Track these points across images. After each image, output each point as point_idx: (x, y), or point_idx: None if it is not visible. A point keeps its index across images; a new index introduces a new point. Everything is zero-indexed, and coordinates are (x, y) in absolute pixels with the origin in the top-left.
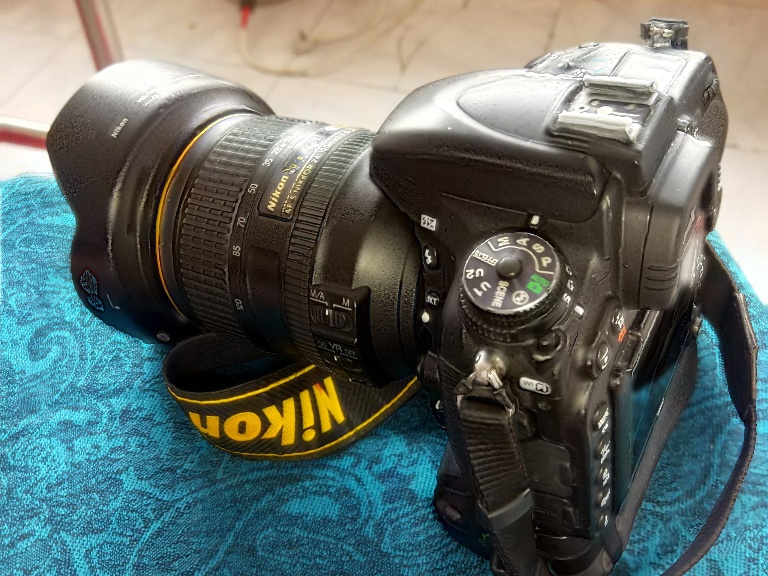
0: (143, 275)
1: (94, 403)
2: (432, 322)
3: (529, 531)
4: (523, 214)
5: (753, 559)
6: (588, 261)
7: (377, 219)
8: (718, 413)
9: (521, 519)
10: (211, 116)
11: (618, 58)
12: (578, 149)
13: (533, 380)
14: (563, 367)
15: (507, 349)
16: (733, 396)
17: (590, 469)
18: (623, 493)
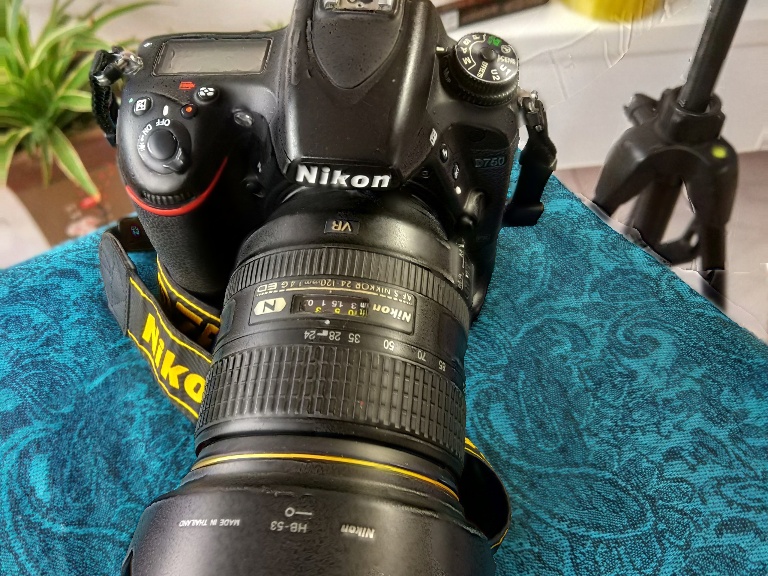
0: None
1: None
2: None
3: None
4: None
5: None
6: (447, 37)
7: (399, 218)
8: None
9: None
10: (274, 461)
11: (172, 77)
12: (404, 3)
13: None
14: None
15: None
16: None
17: None
18: None
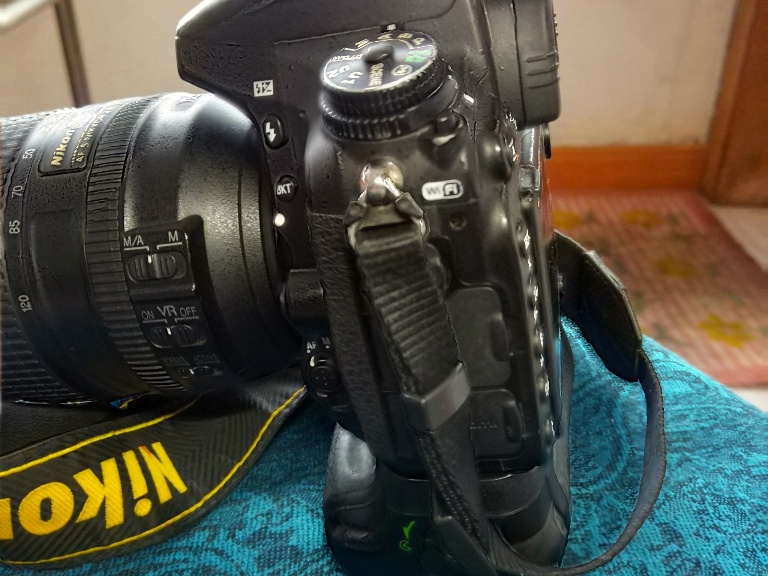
0: None
1: None
2: (289, 221)
3: (470, 449)
4: (375, 28)
5: (702, 511)
6: (461, 58)
7: (196, 139)
8: (605, 391)
9: (460, 414)
10: None
11: None
12: None
13: (438, 182)
14: (470, 154)
15: (398, 149)
16: (614, 367)
17: (526, 318)
18: (558, 404)
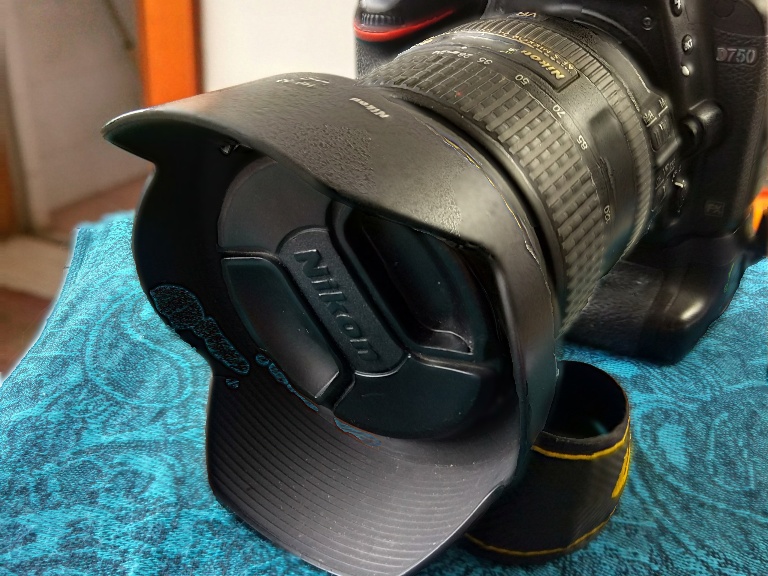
0: None
1: None
2: (691, 69)
3: None
4: None
5: None
6: None
7: None
8: None
9: None
10: None
11: None
12: None
13: None
14: None
15: None
16: None
17: None
18: None
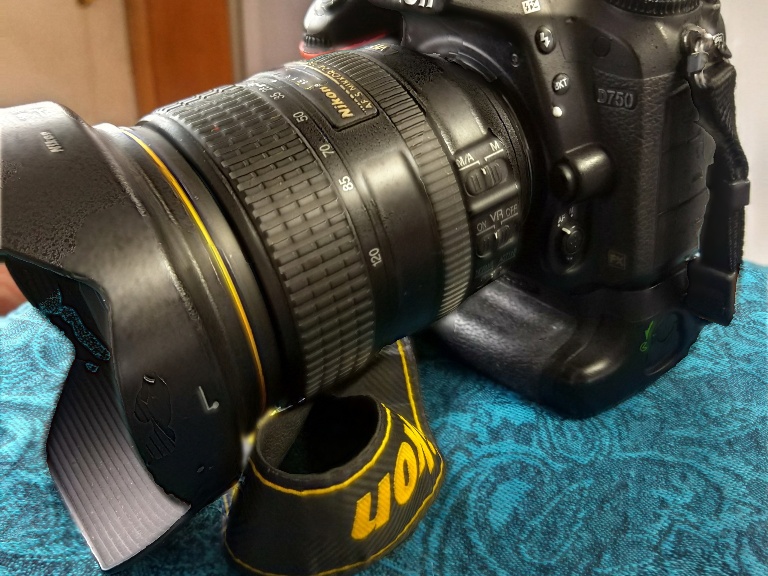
0: (222, 327)
1: None
2: (565, 110)
3: None
4: None
5: None
6: None
7: None
8: None
9: None
10: None
11: None
12: None
13: None
14: None
15: (695, 17)
16: None
17: None
18: None
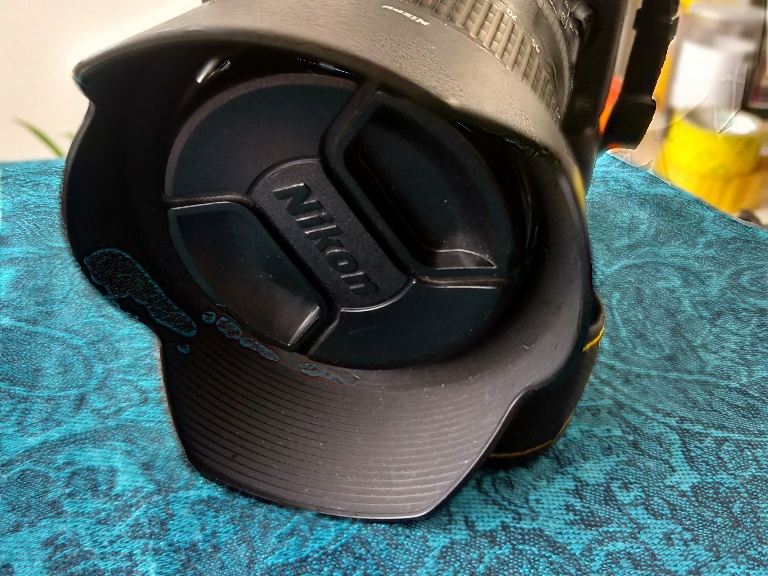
0: None
1: (598, 574)
2: None
3: None
4: None
5: None
6: None
7: None
8: None
9: None
10: None
11: None
12: None
13: None
14: None
15: None
16: None
17: None
18: None
